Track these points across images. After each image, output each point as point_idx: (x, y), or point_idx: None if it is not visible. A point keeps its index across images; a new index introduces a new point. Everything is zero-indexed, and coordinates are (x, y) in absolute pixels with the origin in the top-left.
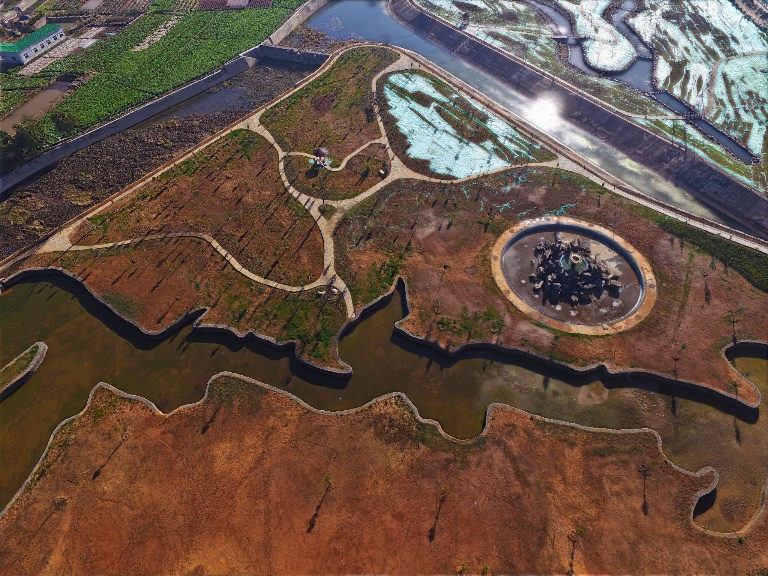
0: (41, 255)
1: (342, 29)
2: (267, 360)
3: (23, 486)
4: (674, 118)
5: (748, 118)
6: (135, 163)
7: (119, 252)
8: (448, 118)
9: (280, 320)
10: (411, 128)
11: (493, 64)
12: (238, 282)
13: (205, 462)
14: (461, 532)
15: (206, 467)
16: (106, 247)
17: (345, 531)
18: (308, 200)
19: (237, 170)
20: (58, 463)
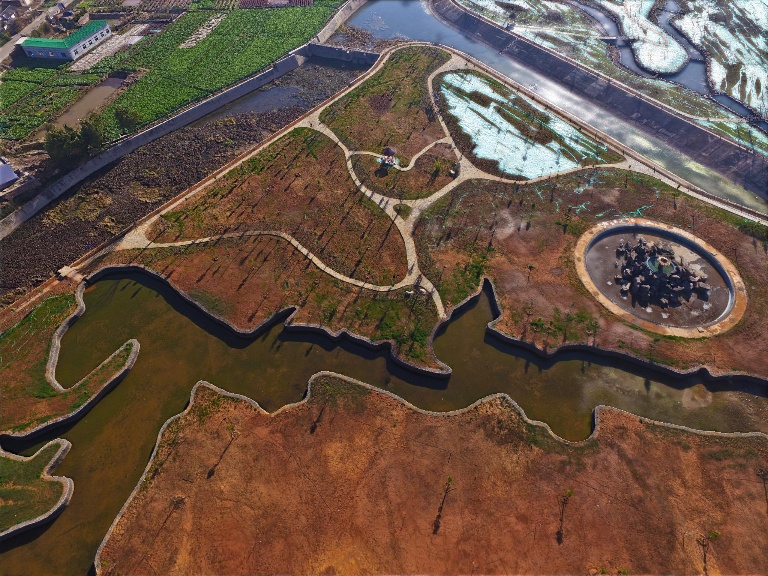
0: (120, 252)
1: (386, 28)
2: (363, 360)
3: (138, 484)
4: (737, 121)
5: None
6: (198, 160)
7: (199, 250)
8: (509, 118)
9: (372, 320)
10: (474, 128)
11: (544, 65)
12: (324, 281)
13: (319, 462)
14: (588, 535)
15: (321, 467)
16: (185, 245)
17: (472, 533)
18: (382, 199)
19: (305, 168)
20: (170, 461)
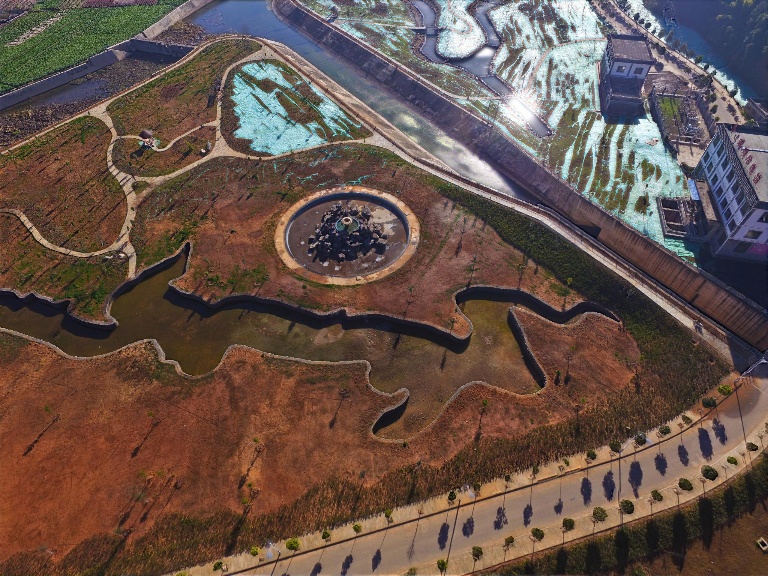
0: None
1: (221, 24)
2: (42, 317)
3: None
4: (492, 98)
5: (557, 97)
6: None
7: None
8: (285, 102)
9: (63, 282)
10: (246, 112)
11: (350, 54)
12: (34, 251)
13: None
14: (162, 449)
15: None
16: None
17: (57, 453)
18: (125, 177)
19: (67, 153)
20: None
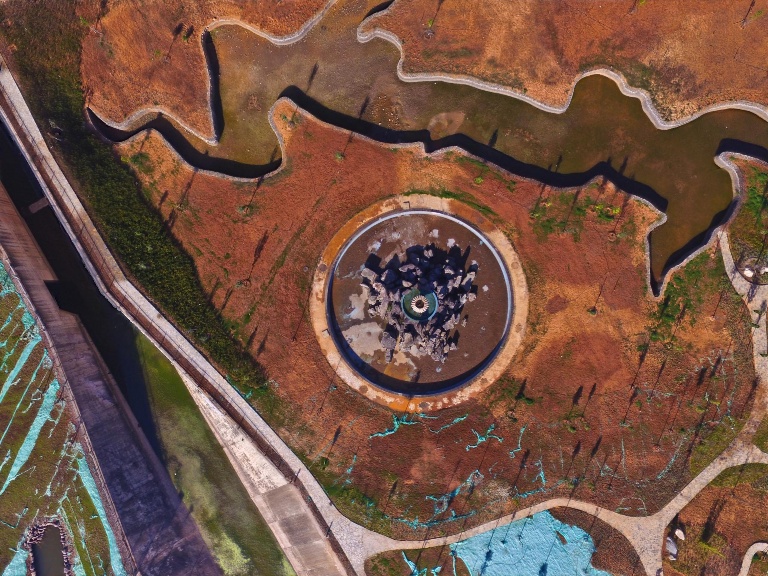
0: None
1: None
2: None
3: None
4: None
5: None
6: None
7: None
8: None
9: None
10: None
11: None
12: None
13: None
14: None
15: None
16: None
17: None
18: None
19: None
20: None
